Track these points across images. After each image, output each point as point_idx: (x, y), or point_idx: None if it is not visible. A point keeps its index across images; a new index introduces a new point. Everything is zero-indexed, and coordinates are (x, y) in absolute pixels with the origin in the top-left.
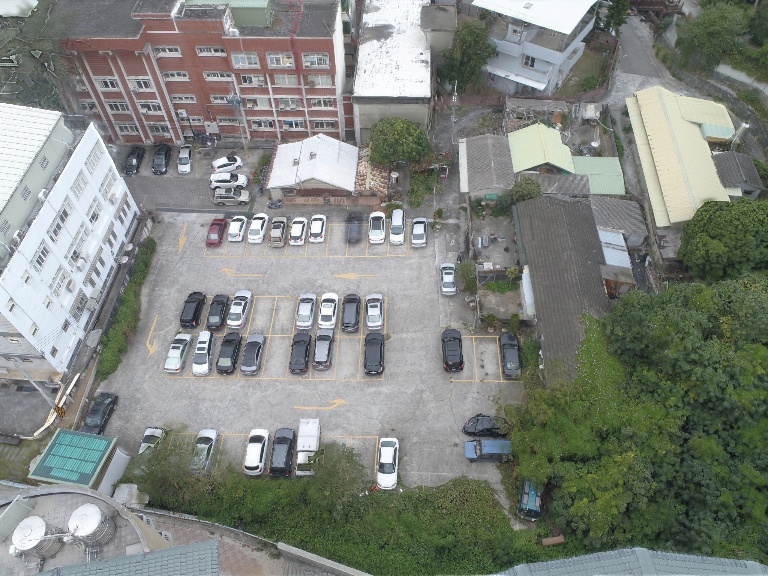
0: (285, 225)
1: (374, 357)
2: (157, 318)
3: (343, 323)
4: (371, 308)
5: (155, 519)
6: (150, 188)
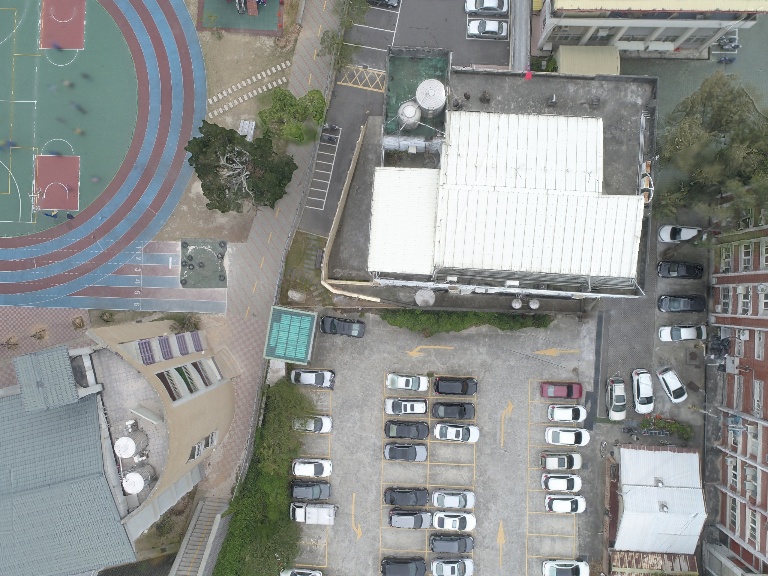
0: (568, 469)
1: (394, 572)
2: (450, 349)
3: (435, 539)
4: (451, 568)
5: (257, 396)
6: None
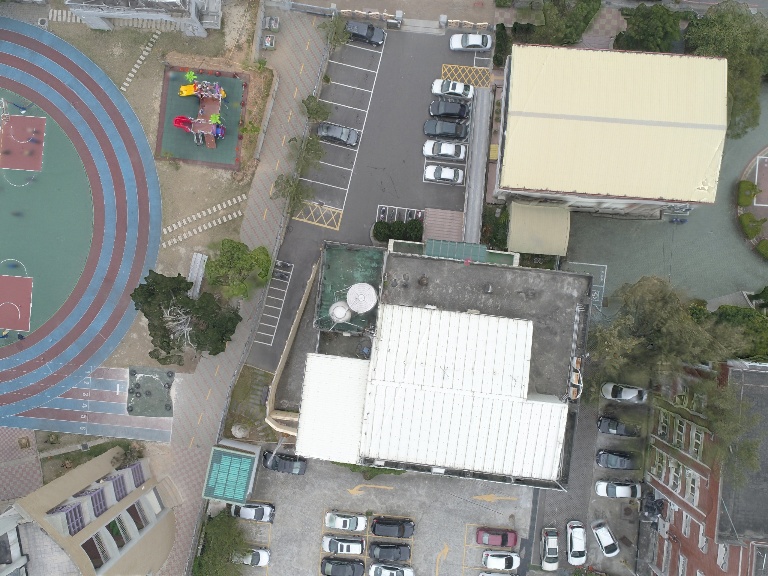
0: None
1: None
2: (390, 489)
3: None
4: None
5: (197, 526)
6: (576, 448)
